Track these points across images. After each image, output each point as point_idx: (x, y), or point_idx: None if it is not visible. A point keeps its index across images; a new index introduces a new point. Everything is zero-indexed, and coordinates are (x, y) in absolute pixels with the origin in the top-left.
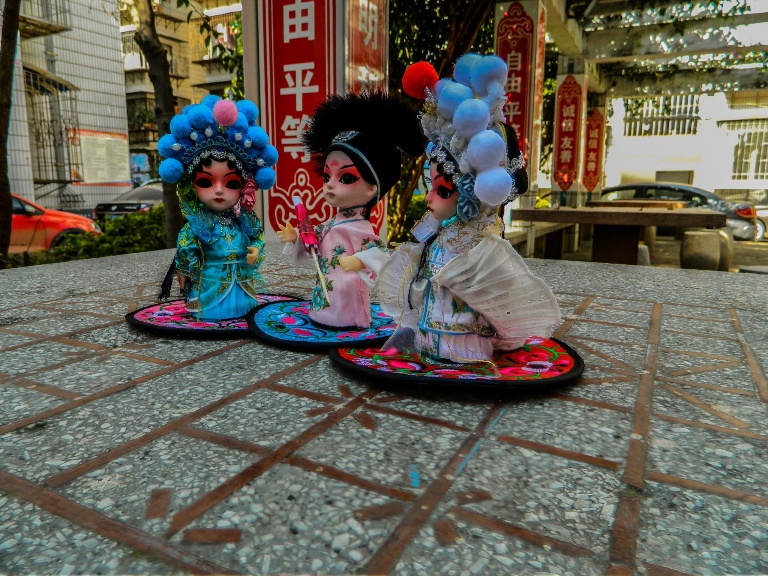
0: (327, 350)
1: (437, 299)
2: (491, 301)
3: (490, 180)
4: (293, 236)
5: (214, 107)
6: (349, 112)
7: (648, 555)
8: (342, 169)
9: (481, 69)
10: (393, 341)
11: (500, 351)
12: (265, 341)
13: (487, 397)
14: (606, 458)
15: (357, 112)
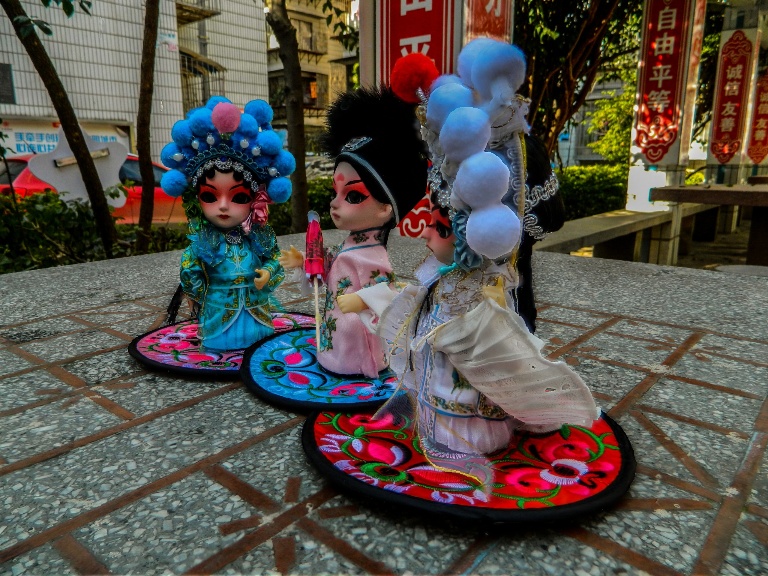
0: (309, 412)
1: (435, 366)
2: (494, 384)
3: (482, 225)
4: (299, 262)
5: (212, 112)
6: (363, 113)
7: None
8: (348, 185)
9: (481, 63)
10: (389, 408)
11: (526, 433)
12: (250, 390)
13: (470, 525)
14: None
15: (372, 113)
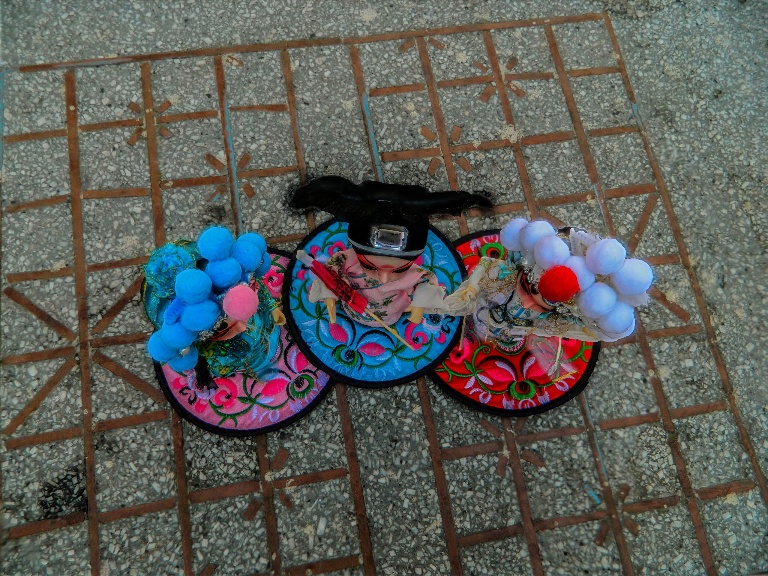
0: None
1: (515, 328)
2: None
3: None
4: None
5: (234, 316)
6: None
7: (695, 484)
8: None
9: None
10: None
11: None
12: None
13: None
14: (651, 411)
15: None
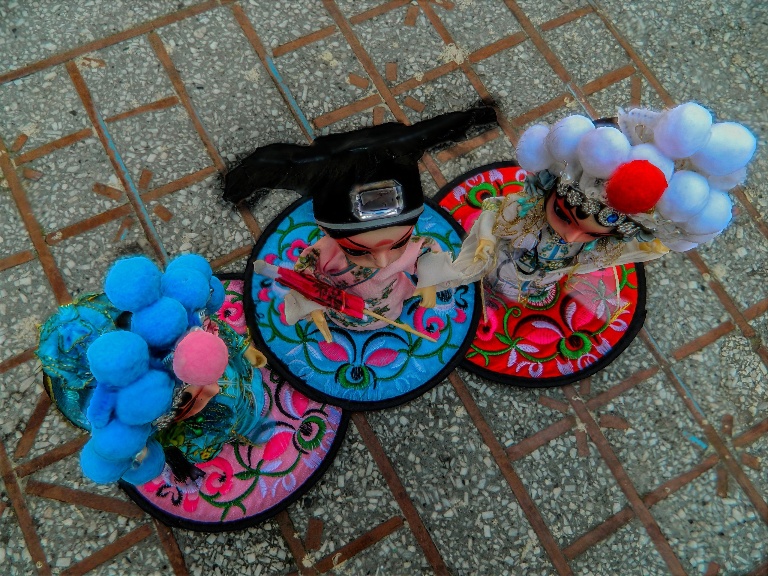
0: None
1: None
2: None
3: None
4: None
5: (197, 382)
6: None
7: None
8: None
9: None
10: None
11: None
12: None
13: None
14: (722, 320)
15: None
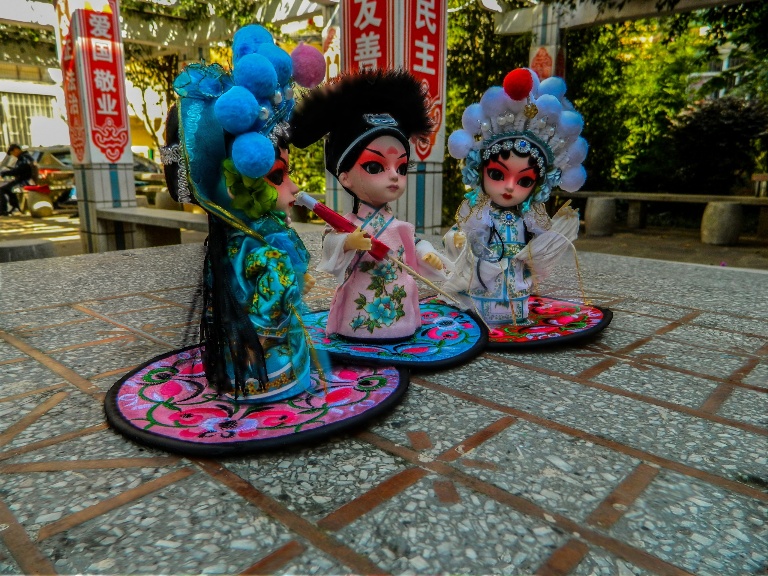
0: None
1: (516, 272)
2: None
3: None
4: None
5: (311, 55)
6: None
7: None
8: (401, 158)
9: None
10: None
11: None
12: (439, 368)
13: None
14: None
15: (374, 91)
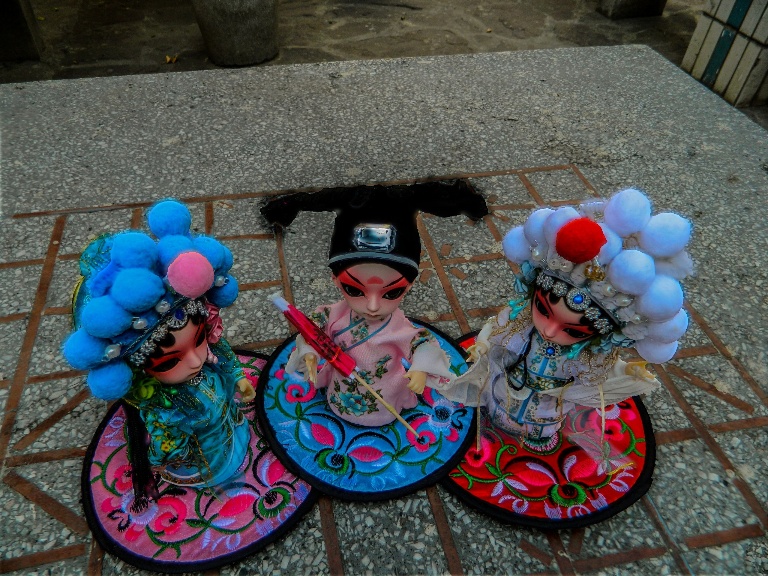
0: (436, 482)
1: (542, 402)
2: None
3: (671, 354)
4: (315, 363)
5: (180, 282)
6: None
7: None
8: (389, 287)
9: (678, 246)
10: None
11: None
12: None
13: None
14: (748, 522)
15: None
